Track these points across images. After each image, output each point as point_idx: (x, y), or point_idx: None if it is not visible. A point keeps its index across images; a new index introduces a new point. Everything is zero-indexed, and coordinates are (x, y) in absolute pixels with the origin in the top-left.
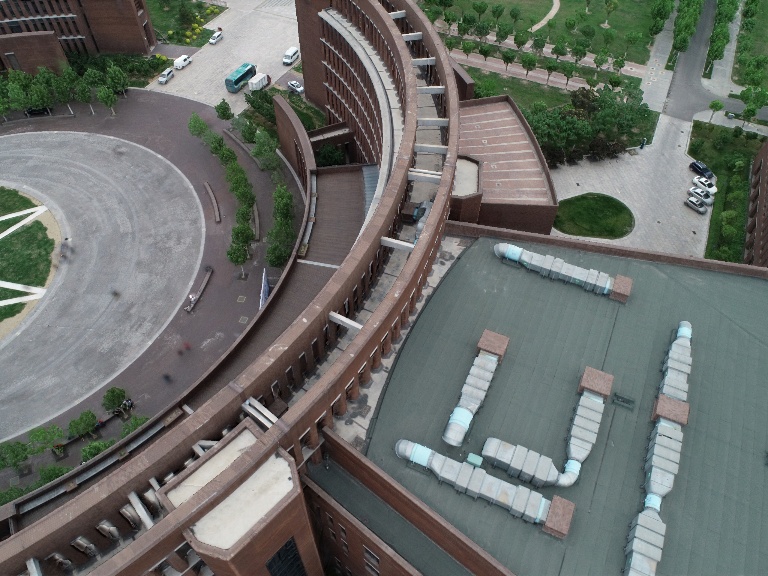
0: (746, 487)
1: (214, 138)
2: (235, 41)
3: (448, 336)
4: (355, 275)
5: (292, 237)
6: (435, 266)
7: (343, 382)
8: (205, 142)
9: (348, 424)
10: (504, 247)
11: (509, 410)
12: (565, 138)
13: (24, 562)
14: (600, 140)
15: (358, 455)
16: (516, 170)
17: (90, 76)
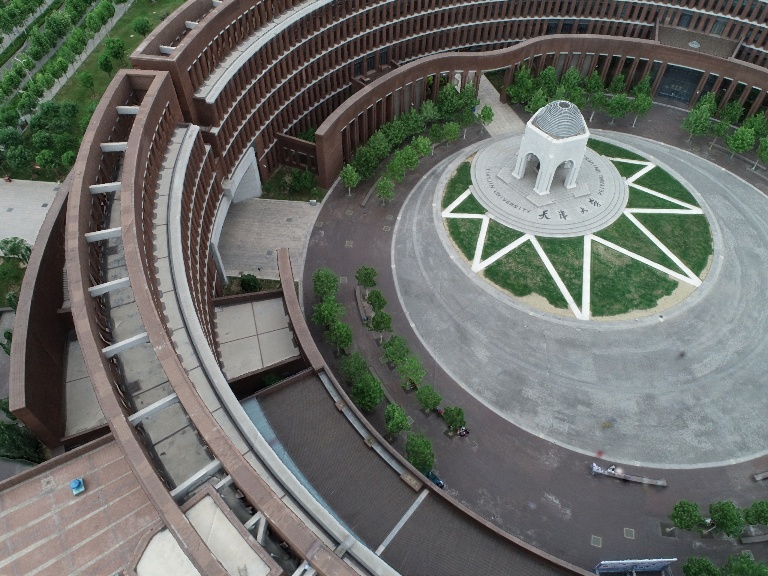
0: None
1: None
2: None
3: None
4: None
5: None
6: None
7: None
8: None
9: None
10: None
11: None
12: None
13: None
14: None
15: None
16: None
17: None
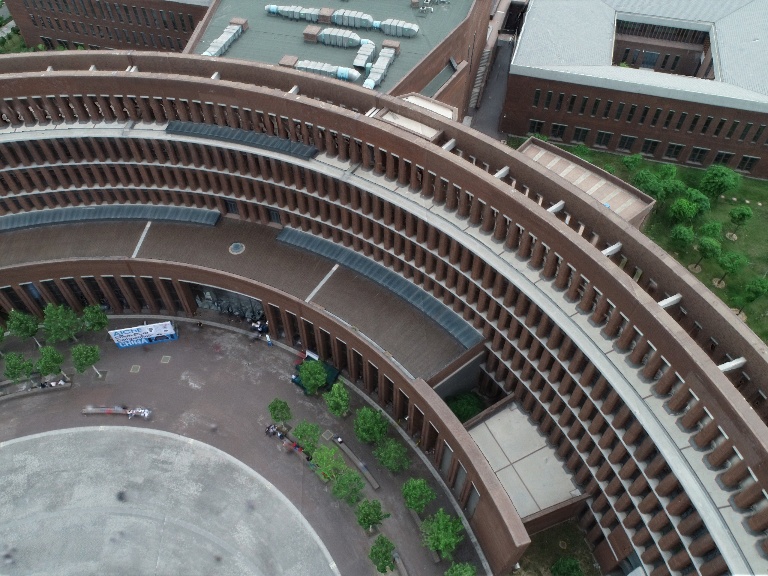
0: (360, 8)
1: None
2: None
3: None
4: None
5: None
6: None
7: None
8: None
9: None
10: None
11: None
12: None
13: None
14: None
15: None
16: None
17: None
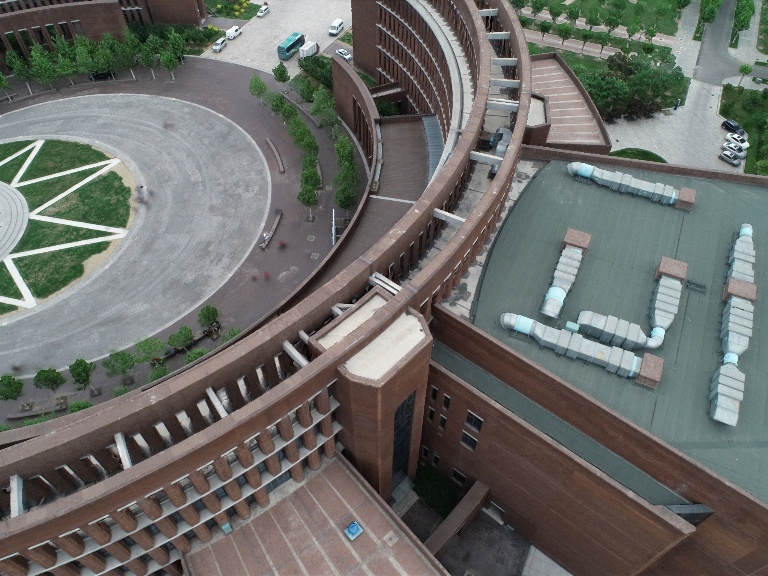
0: None
1: (276, 96)
2: (281, 14)
3: (533, 237)
4: (453, 180)
5: (357, 181)
6: (513, 184)
7: (455, 261)
8: (265, 101)
9: (452, 306)
10: (577, 165)
11: (595, 294)
12: (605, 97)
13: (204, 390)
14: (637, 100)
15: (468, 324)
16: (568, 117)
17: (151, 42)
